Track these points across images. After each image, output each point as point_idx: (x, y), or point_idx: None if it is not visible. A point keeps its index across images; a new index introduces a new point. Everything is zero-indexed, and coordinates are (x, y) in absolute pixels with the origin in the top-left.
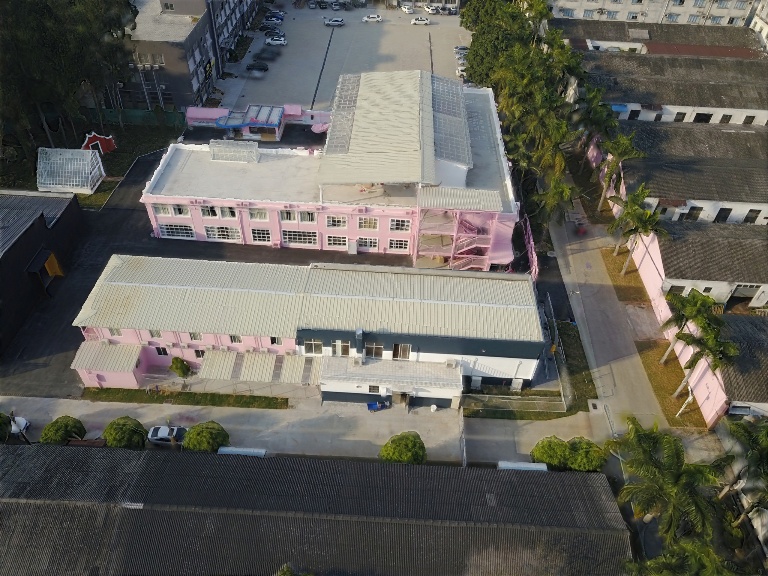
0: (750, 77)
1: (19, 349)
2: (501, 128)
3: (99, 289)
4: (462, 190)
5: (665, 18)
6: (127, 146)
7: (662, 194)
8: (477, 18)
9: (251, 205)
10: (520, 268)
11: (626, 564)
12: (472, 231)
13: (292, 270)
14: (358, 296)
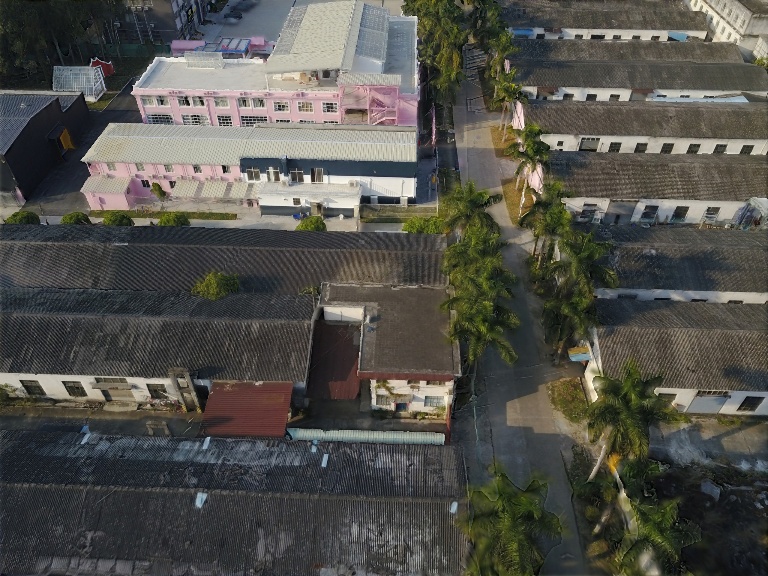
0: (644, 8)
1: (43, 190)
2: (417, 41)
3: (100, 139)
4: (373, 75)
5: None
6: (124, 71)
7: (539, 83)
8: None
9: (215, 94)
10: (424, 139)
11: (444, 269)
12: None
13: (241, 129)
14: (287, 140)
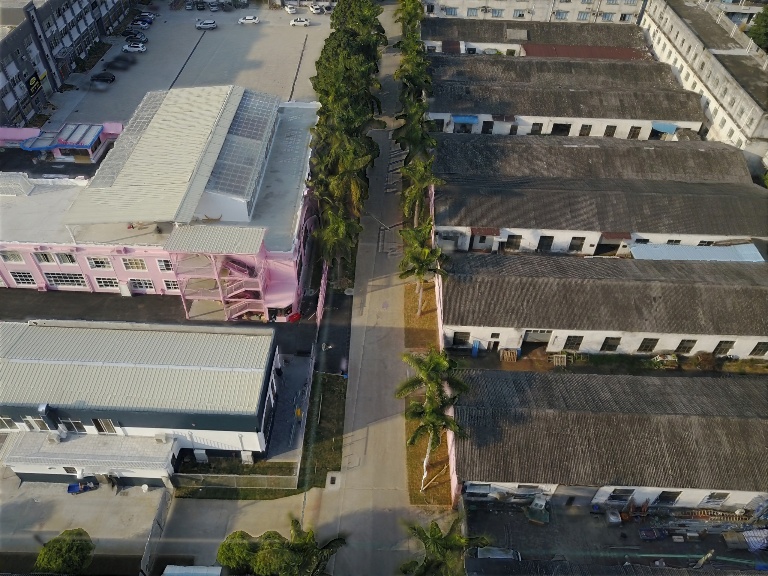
0: (622, 81)
1: None
2: None
3: None
4: (224, 228)
5: (553, 15)
6: None
7: (474, 222)
8: (345, 20)
9: None
10: (307, 310)
11: None
12: (242, 272)
13: (6, 328)
14: (64, 361)
